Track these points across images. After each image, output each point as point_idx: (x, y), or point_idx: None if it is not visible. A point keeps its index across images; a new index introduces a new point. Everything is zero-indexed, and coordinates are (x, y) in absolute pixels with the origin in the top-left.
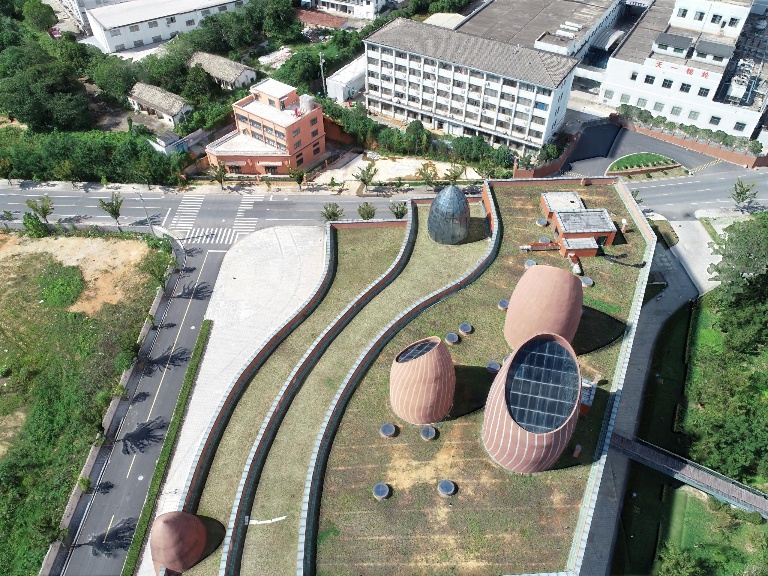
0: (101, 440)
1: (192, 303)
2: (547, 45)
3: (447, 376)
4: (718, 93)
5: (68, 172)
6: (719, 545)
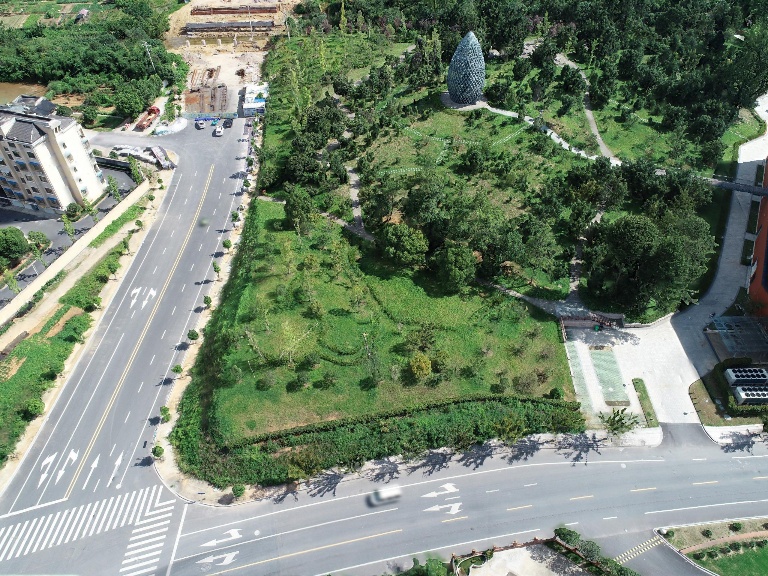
0: None
1: None
2: None
3: None
4: None
5: None
6: (681, 171)
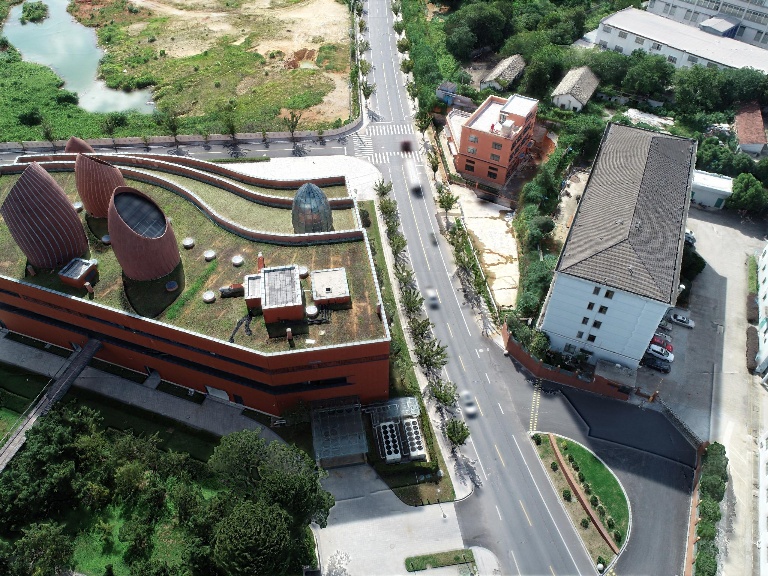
0: (165, 133)
1: (288, 150)
2: None
3: (79, 179)
4: None
5: (406, 67)
6: None
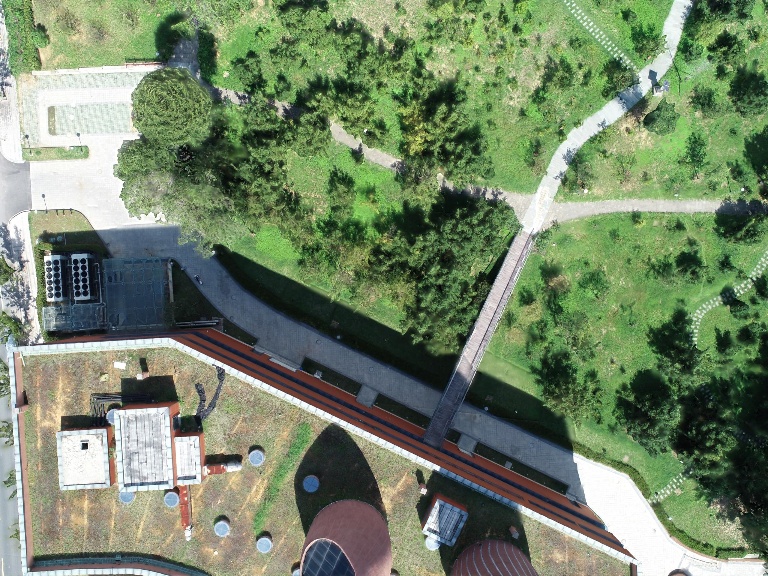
0: None
1: None
2: None
3: None
4: None
5: None
6: (528, 337)
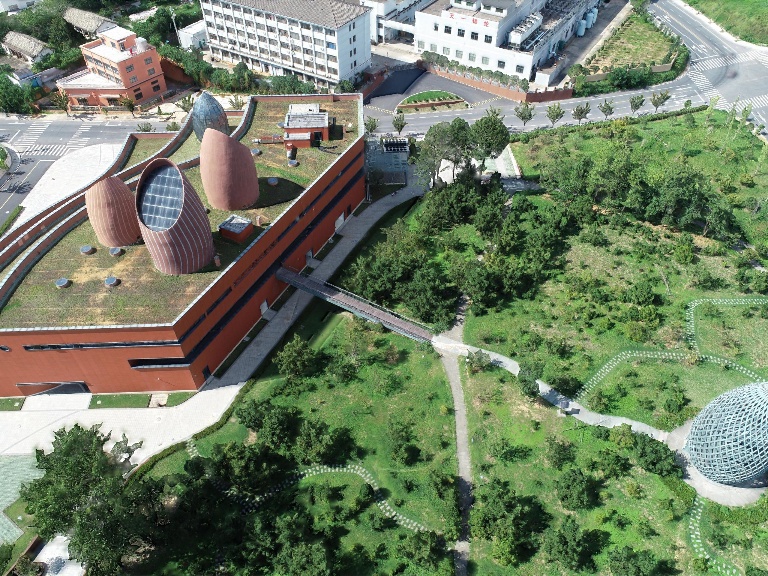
0: None
1: (13, 196)
2: (369, 2)
3: (120, 204)
4: (504, 41)
5: None
6: (349, 346)
